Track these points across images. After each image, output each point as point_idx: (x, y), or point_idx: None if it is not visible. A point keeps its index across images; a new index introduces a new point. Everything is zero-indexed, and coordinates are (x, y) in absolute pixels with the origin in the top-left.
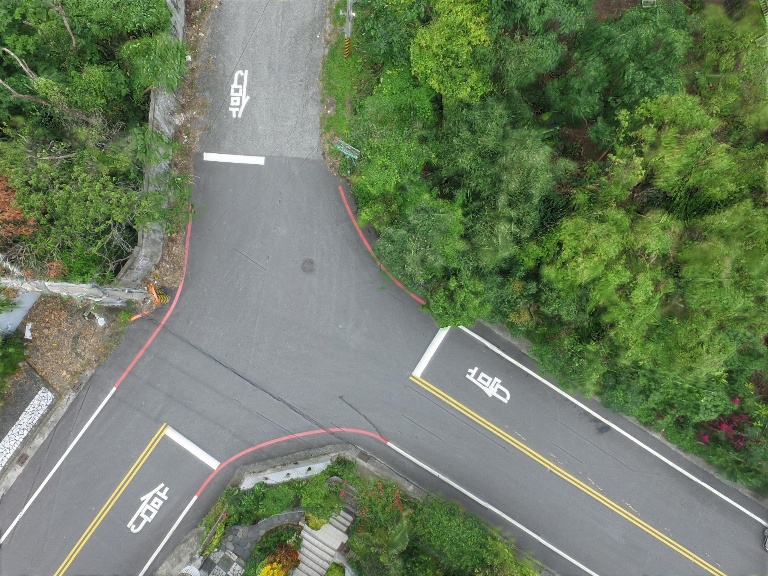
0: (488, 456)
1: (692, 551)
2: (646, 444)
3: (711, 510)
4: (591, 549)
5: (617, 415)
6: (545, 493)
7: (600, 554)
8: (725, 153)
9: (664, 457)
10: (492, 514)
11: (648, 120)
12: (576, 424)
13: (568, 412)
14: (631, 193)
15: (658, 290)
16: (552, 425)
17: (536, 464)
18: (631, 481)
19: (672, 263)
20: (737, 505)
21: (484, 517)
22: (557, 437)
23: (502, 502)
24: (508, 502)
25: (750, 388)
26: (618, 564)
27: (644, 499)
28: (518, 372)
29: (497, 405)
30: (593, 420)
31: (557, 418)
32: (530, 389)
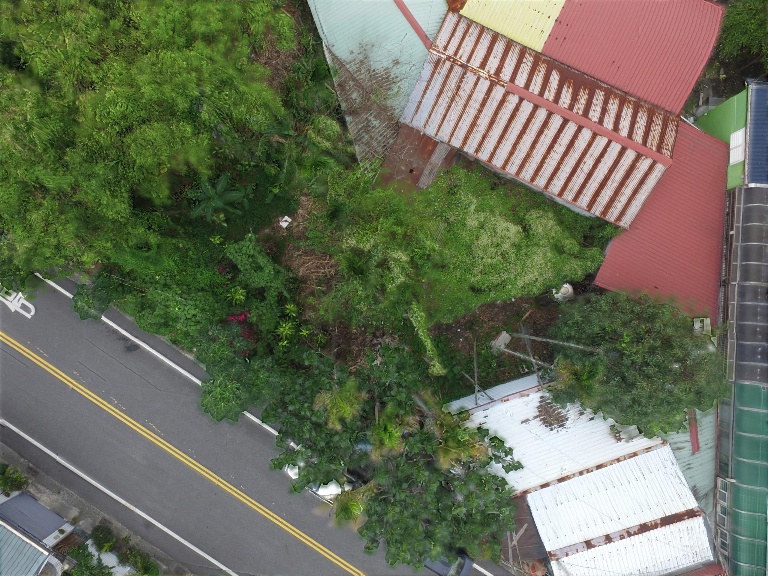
0: (7, 372)
1: (215, 473)
2: (177, 364)
3: (240, 432)
4: (111, 469)
5: (149, 334)
6: (65, 411)
7: (120, 475)
8: (166, 49)
9: (195, 377)
10: (9, 432)
11: (55, 6)
12: (103, 342)
13: (96, 329)
14: (14, 75)
15: (1, 168)
16: (77, 342)
17: (58, 381)
18: (156, 401)
19: (7, 139)
20: (269, 428)
21: (1, 435)
22: (82, 354)
23: (20, 420)
24: (26, 420)
25: (292, 310)
26: (138, 485)
27: (169, 419)
28: (45, 287)
29: (20, 320)
30: (122, 338)
31: (83, 335)
32: (57, 305)
